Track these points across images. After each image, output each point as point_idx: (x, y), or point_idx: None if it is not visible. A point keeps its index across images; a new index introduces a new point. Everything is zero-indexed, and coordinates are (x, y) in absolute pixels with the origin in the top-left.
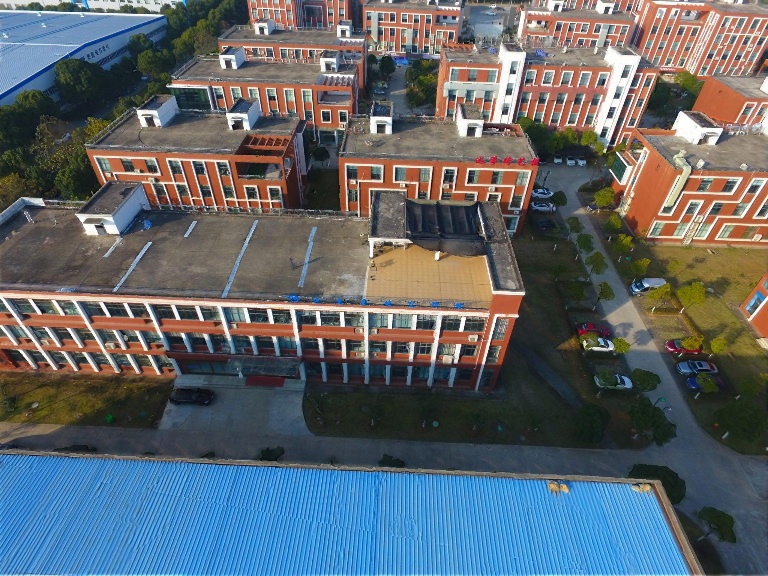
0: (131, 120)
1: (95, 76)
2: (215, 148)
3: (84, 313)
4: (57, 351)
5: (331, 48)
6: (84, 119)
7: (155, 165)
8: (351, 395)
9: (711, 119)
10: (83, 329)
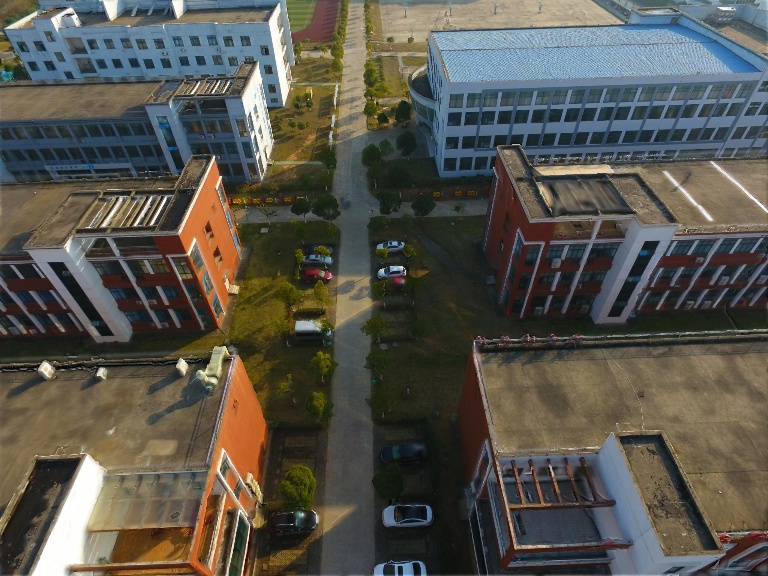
0: None
1: None
2: None
3: None
4: None
5: None
6: None
7: None
8: None
9: (5, 514)
10: None
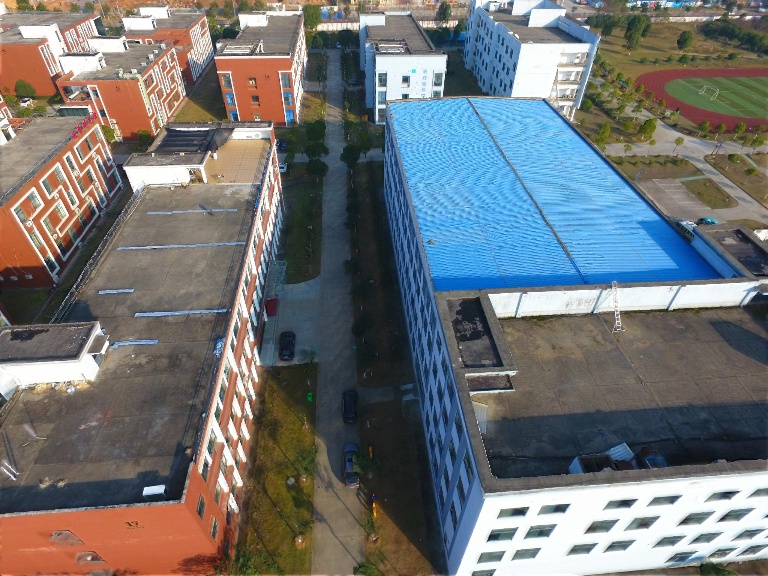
0: None
1: None
2: None
3: None
4: None
5: None
6: None
7: None
8: None
9: None
10: None
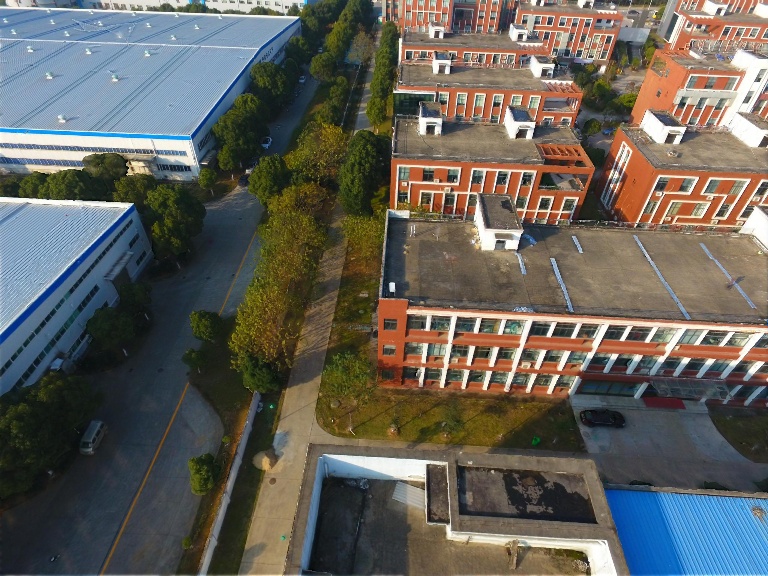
0: (401, 127)
1: (288, 80)
2: (516, 158)
3: (528, 333)
4: (458, 369)
5: (517, 52)
6: (271, 123)
7: (456, 175)
8: (759, 419)
9: None
10: (507, 348)
